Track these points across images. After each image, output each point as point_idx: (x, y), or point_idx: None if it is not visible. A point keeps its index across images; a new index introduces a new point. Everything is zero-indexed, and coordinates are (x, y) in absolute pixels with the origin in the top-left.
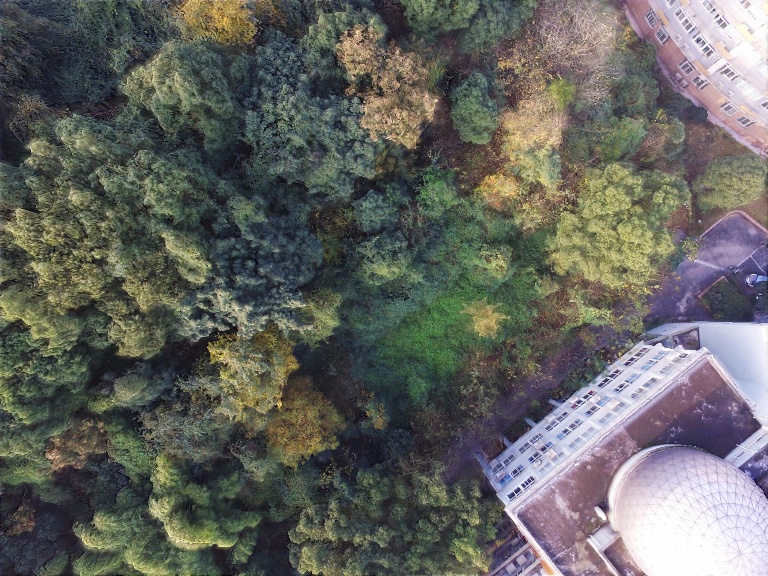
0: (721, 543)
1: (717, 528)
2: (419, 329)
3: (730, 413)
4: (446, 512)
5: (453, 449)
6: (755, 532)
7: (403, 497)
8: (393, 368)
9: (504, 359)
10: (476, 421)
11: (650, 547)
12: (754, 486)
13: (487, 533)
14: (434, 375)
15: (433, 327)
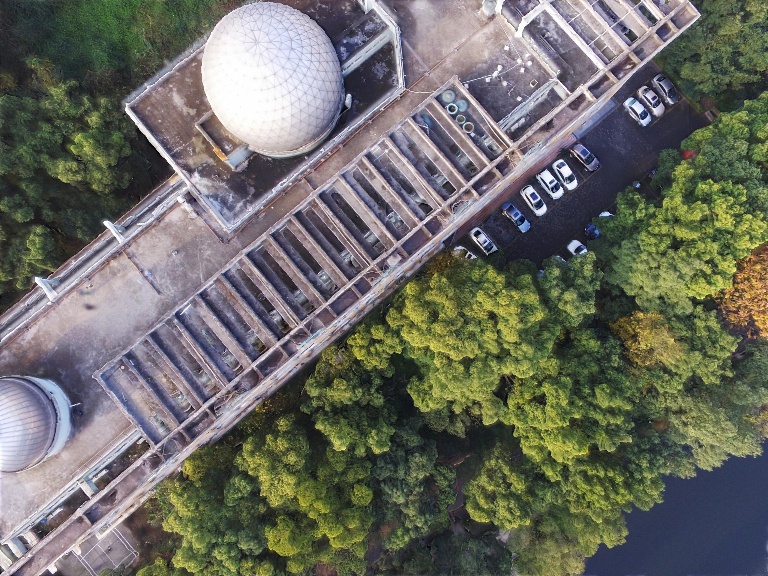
0: (239, 35)
1: (238, 24)
2: (103, 7)
3: (343, 12)
4: (76, 122)
5: (120, 102)
6: (274, 25)
7: (33, 108)
8: (80, 47)
9: (195, 42)
10: (149, 82)
11: (204, 75)
12: (303, 14)
13: (113, 138)
14: (126, 58)
15: (116, 5)
